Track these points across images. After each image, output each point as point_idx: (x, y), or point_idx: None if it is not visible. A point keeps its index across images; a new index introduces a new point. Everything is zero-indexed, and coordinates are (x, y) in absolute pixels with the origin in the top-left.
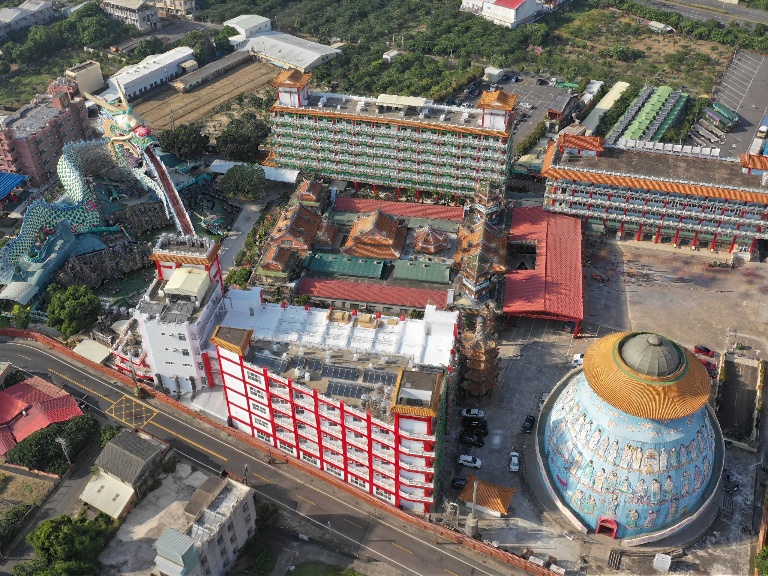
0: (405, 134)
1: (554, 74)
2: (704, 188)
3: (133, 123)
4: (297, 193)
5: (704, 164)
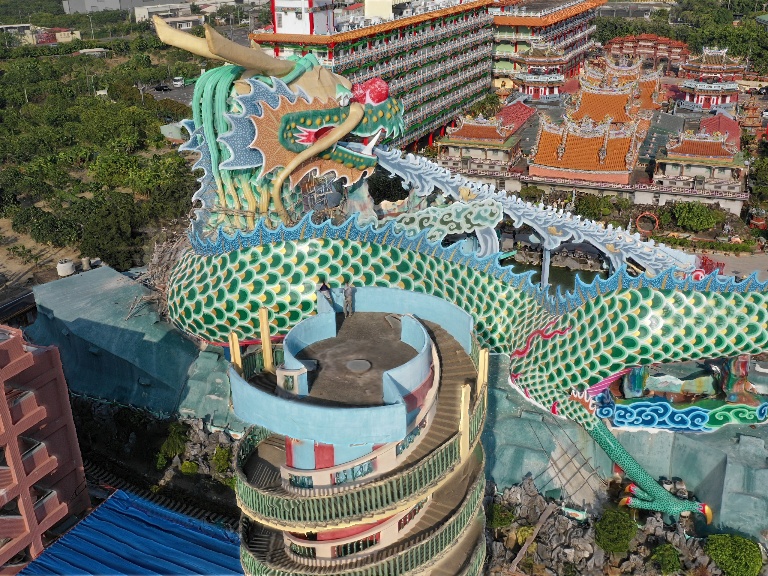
0: (442, 31)
1: (147, 86)
2: (583, 4)
3: (345, 79)
4: (478, 144)
5: (539, 1)
